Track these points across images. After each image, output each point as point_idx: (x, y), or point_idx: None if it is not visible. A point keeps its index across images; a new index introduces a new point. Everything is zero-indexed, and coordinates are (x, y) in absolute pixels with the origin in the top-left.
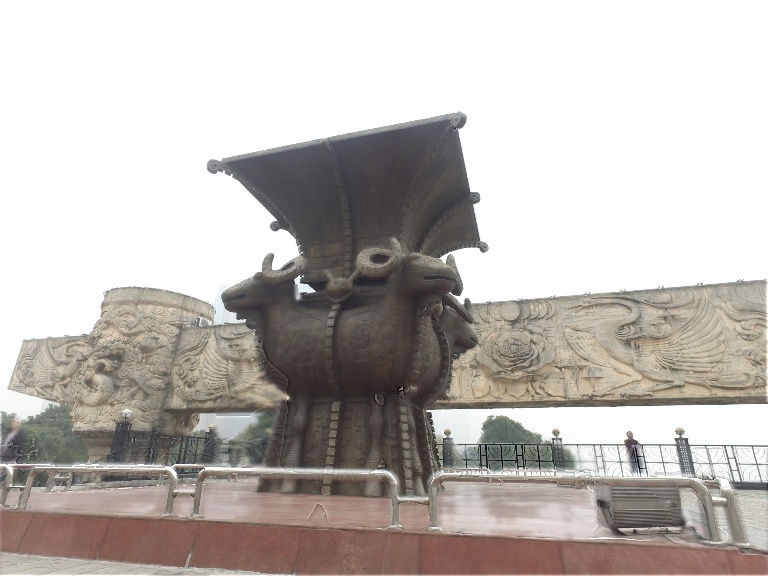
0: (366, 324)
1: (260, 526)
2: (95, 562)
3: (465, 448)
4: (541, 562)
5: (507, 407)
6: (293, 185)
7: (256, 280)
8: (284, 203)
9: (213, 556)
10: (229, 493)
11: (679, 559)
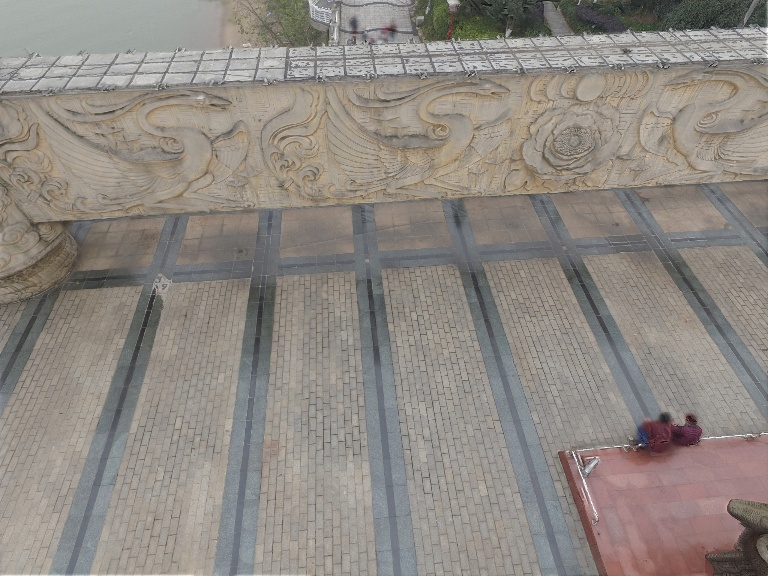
0: None
1: None
2: None
3: None
4: None
5: None
6: None
7: None
8: None
9: None
10: None
11: None
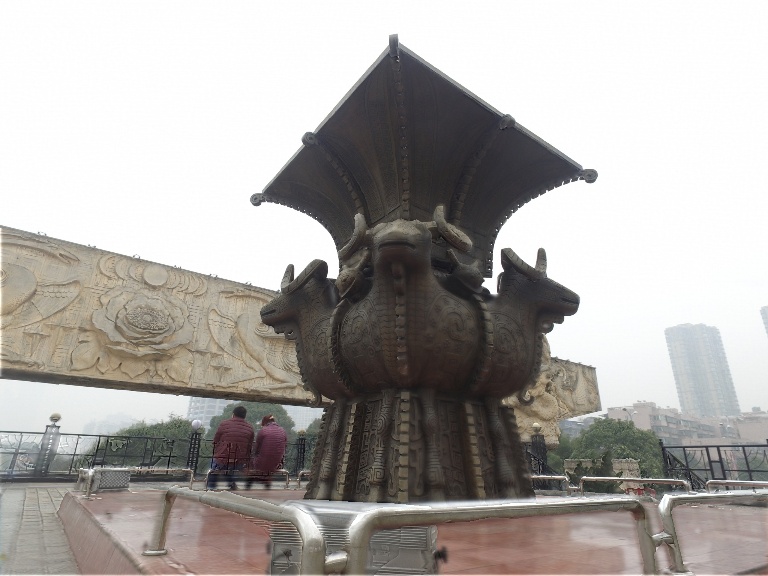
0: None
1: None
2: None
3: None
4: None
5: None
6: None
7: None
8: None
9: None
10: None
11: None
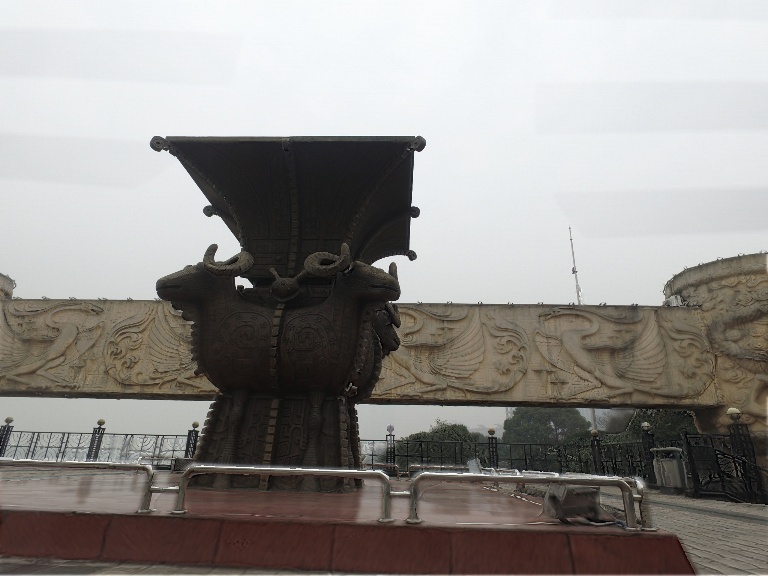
0: None
1: None
2: None
3: None
4: None
5: None
6: None
7: None
8: None
9: None
10: (375, 484)
11: None
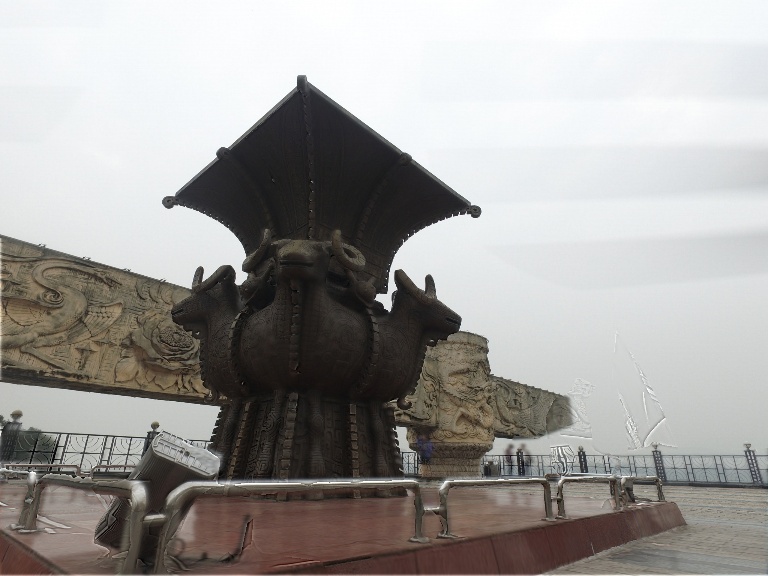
0: (393, 338)
1: (603, 517)
2: (562, 569)
3: (37, 437)
4: (658, 516)
5: (133, 395)
6: (341, 159)
7: (318, 251)
8: (319, 167)
9: (600, 542)
10: (281, 505)
11: (670, 508)
